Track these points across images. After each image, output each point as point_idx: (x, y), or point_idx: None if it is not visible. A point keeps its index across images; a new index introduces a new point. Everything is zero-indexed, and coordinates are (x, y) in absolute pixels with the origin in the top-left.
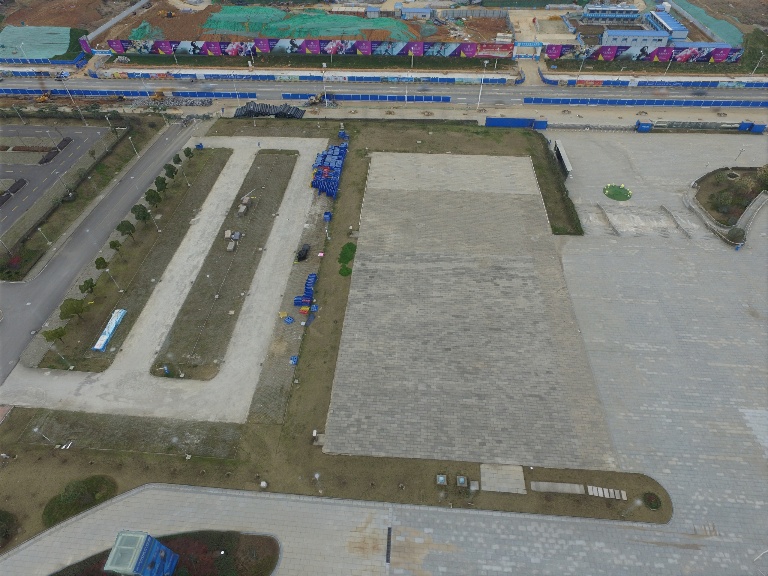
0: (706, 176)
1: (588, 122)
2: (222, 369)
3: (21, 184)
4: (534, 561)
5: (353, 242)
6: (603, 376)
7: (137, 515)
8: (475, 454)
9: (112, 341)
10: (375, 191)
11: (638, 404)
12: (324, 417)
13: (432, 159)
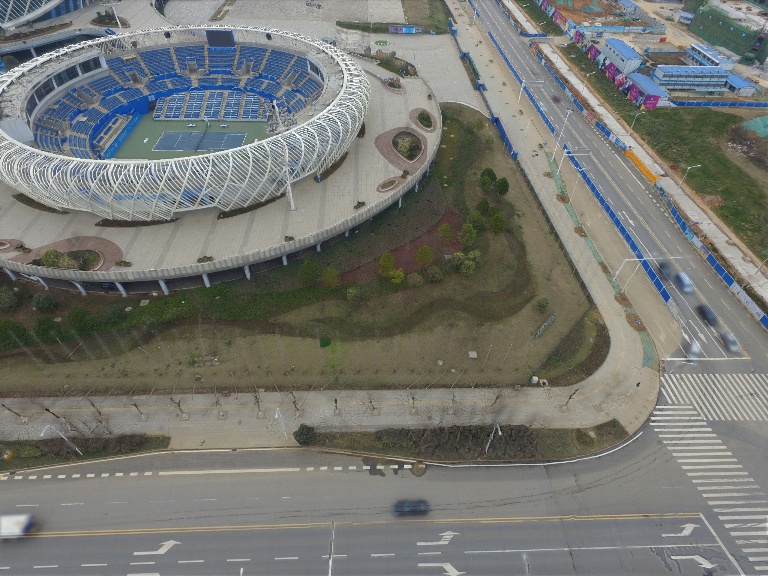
0: (402, 60)
1: (469, 46)
2: None
3: None
4: None
5: None
6: None
7: None
8: None
9: None
10: None
11: (245, 22)
12: None
13: None
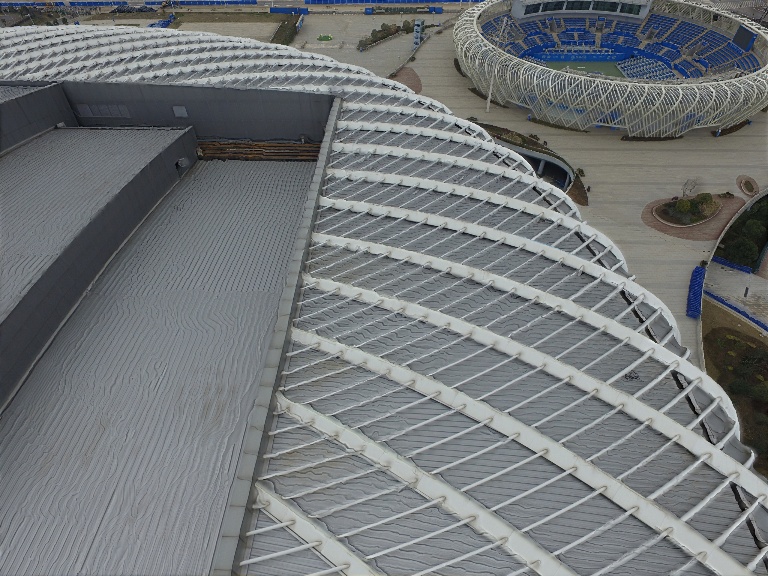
0: None
1: None
2: None
3: None
4: None
5: None
6: None
7: None
8: None
9: None
10: None
11: None
12: None
13: (219, 24)
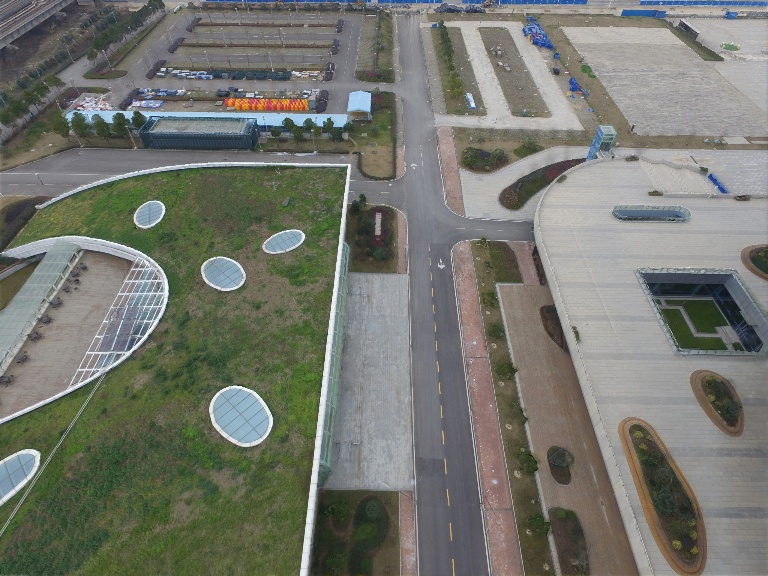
0: None
1: None
2: (553, 114)
3: None
4: (766, 162)
5: (586, 65)
6: (767, 110)
7: (562, 154)
8: (718, 134)
9: (477, 105)
10: (579, 44)
11: None
12: (628, 125)
13: (604, 29)
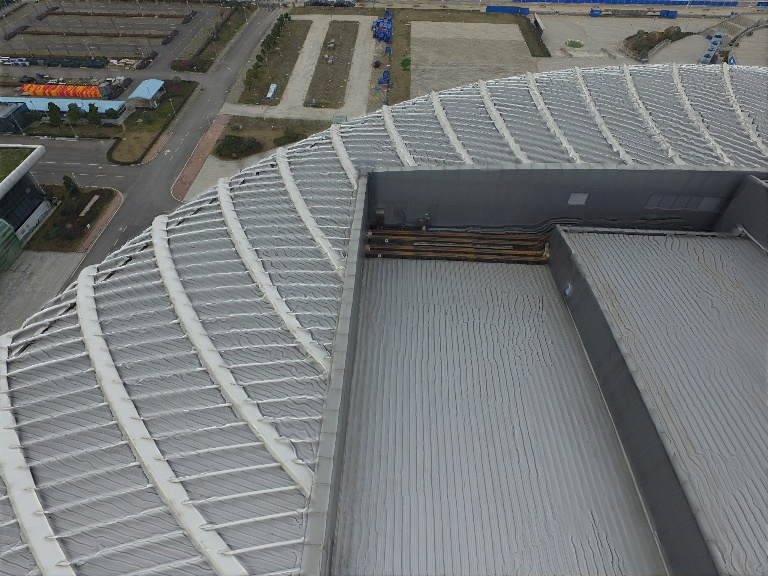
0: (633, 36)
1: None
2: (344, 105)
3: (177, 32)
4: None
5: (408, 58)
6: None
7: None
8: None
9: (275, 96)
10: (417, 38)
11: None
12: None
13: (452, 24)
